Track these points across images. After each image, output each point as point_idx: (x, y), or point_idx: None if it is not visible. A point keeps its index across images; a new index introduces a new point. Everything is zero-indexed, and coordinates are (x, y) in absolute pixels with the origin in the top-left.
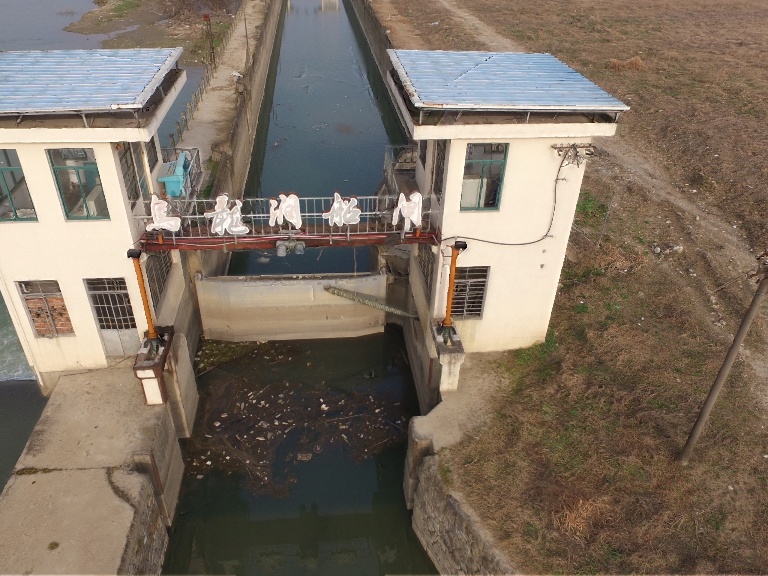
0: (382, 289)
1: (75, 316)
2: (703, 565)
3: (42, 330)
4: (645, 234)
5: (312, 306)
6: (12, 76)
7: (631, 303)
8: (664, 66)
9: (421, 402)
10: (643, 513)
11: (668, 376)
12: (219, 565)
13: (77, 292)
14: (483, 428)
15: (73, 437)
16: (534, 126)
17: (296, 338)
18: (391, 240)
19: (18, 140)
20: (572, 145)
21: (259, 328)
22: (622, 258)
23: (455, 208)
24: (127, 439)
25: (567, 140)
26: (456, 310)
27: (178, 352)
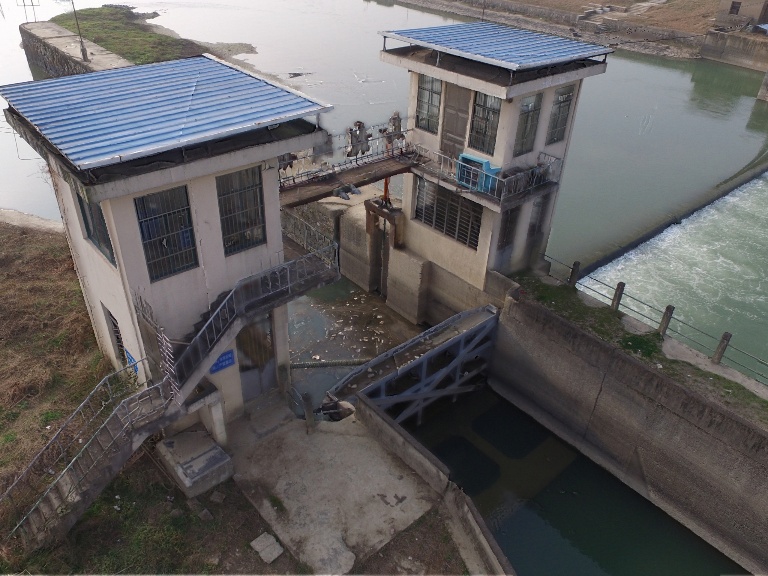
0: None
1: None
2: (1, 256)
3: None
4: None
5: None
6: None
7: None
8: None
9: None
10: None
11: None
12: None
13: None
14: None
15: None
16: None
17: None
18: None
19: None
20: None
21: None
22: None
23: None
24: None
25: None
26: None
27: (405, 253)
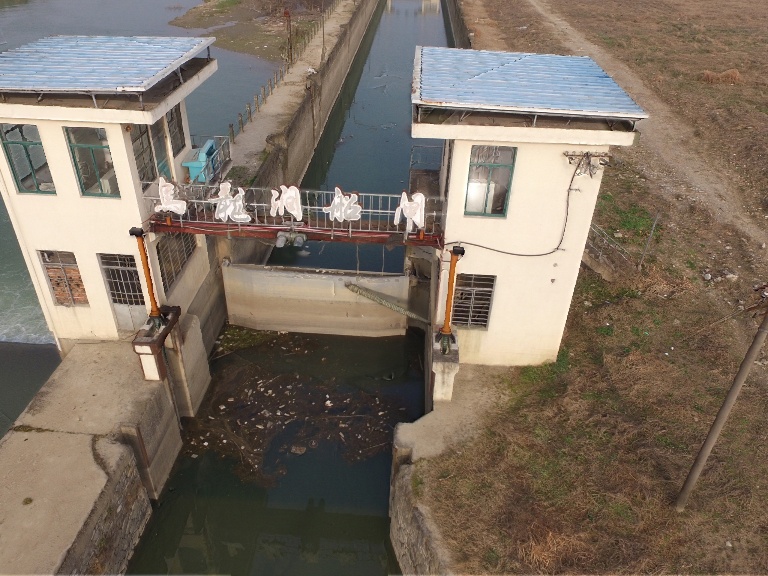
0: (404, 291)
1: (90, 288)
2: None
3: (61, 298)
4: (698, 258)
5: (333, 302)
6: (47, 57)
7: (663, 330)
8: (765, 80)
9: (426, 410)
10: (620, 557)
11: (685, 413)
12: (223, 546)
13: (91, 265)
14: (468, 443)
15: (71, 402)
16: (541, 130)
17: (316, 332)
18: (394, 240)
19: (35, 116)
20: (585, 153)
21: (281, 318)
22: (663, 281)
23: (459, 212)
24: (119, 410)
25: (581, 148)
26: (461, 318)
27: (187, 333)
